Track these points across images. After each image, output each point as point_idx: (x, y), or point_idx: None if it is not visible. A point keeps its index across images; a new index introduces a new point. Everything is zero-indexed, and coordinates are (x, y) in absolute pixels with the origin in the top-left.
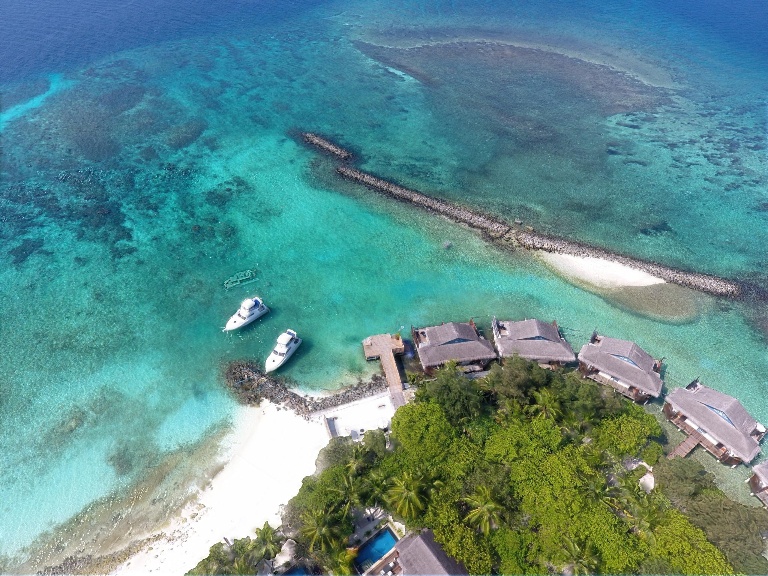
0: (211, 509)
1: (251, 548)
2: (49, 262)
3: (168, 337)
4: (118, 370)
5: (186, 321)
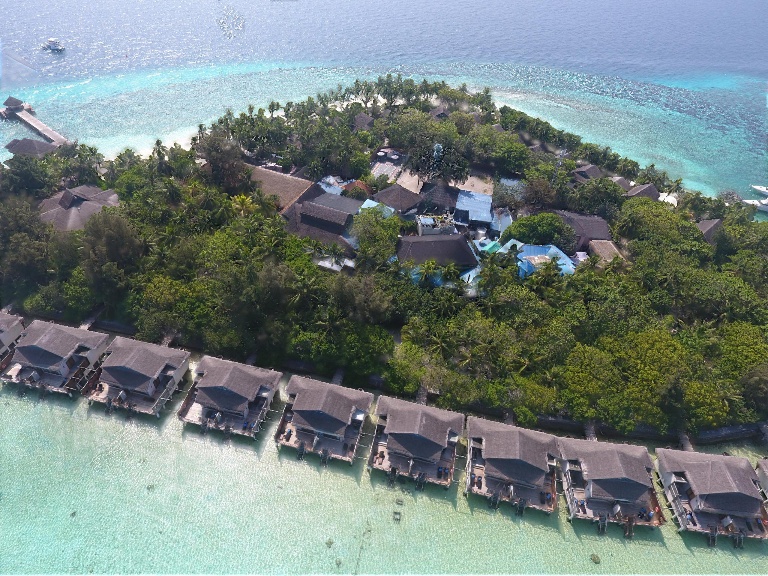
0: (663, 193)
1: (670, 180)
2: (720, 135)
3: (724, 174)
4: (692, 164)
5: (740, 178)
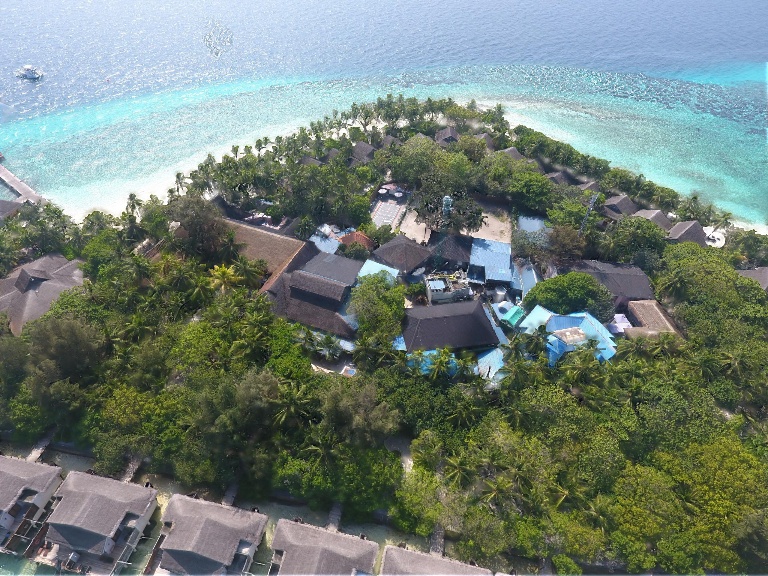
0: None
1: (717, 214)
2: (762, 141)
3: None
4: (734, 181)
5: None
